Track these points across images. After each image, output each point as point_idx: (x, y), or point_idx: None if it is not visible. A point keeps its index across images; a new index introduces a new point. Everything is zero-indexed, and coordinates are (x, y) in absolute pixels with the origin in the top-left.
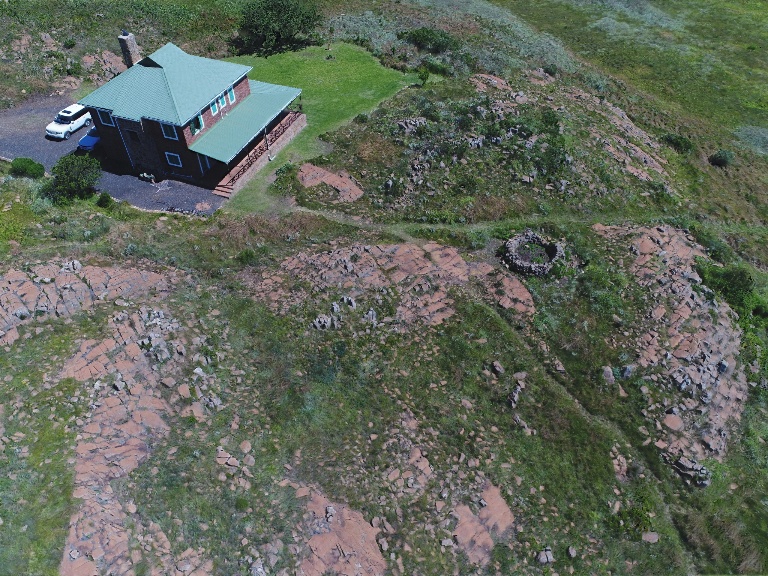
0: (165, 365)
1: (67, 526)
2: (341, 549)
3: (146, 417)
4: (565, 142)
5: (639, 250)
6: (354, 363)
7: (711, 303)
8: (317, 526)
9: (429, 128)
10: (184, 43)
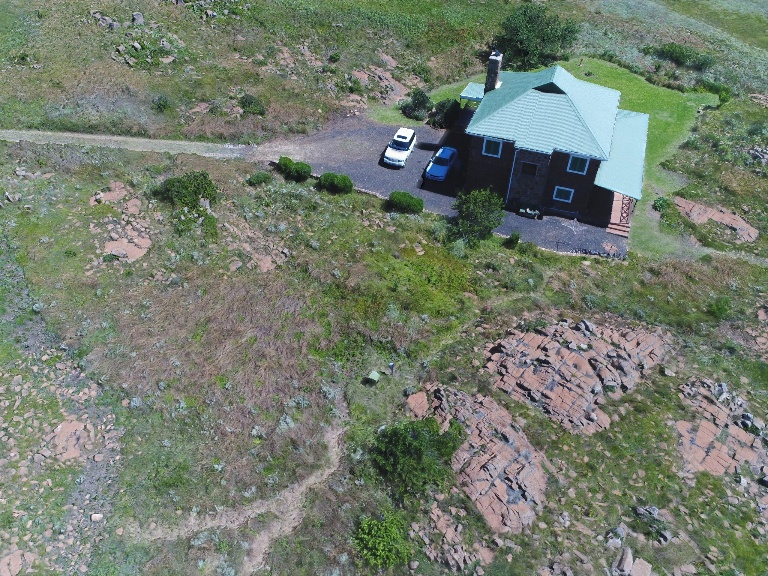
0: None
1: None
2: None
3: None
4: None
5: None
6: None
7: None
8: None
9: None
10: (430, 56)
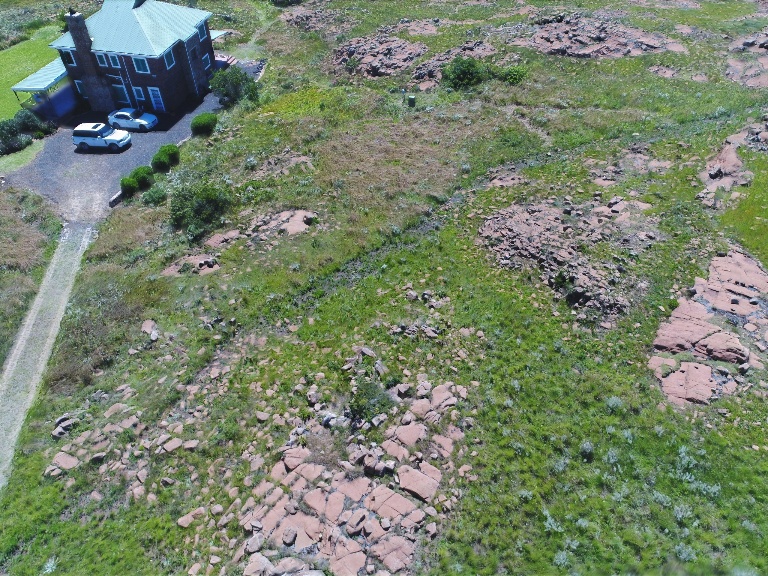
0: None
1: None
2: (477, 1)
3: None
4: None
5: None
6: None
7: None
8: (471, 4)
9: None
10: None
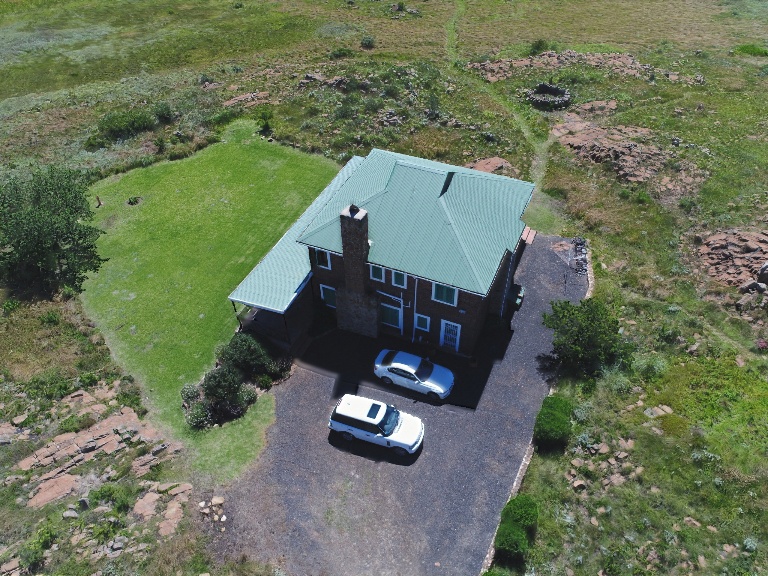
0: None
1: None
2: None
3: None
4: None
5: None
6: None
7: None
8: None
9: None
10: None
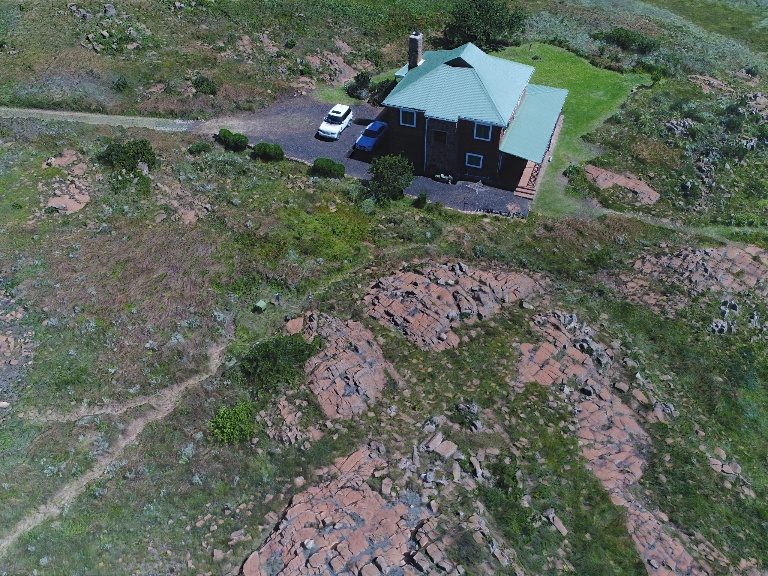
0: (605, 370)
1: (628, 534)
2: None
3: (628, 423)
4: None
5: None
6: (767, 369)
7: None
8: None
9: None
10: (386, 43)
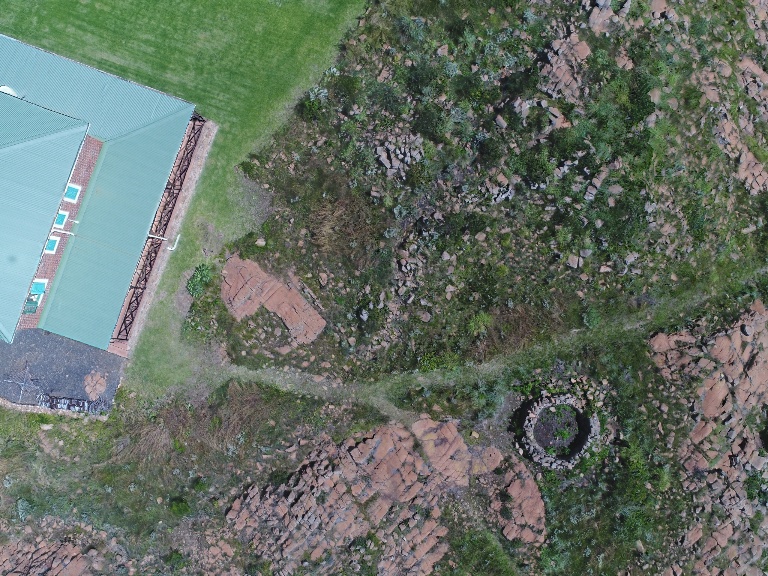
0: None
1: None
2: None
3: None
4: (653, 145)
5: (702, 408)
6: None
7: (763, 503)
8: None
9: (427, 164)
10: None
